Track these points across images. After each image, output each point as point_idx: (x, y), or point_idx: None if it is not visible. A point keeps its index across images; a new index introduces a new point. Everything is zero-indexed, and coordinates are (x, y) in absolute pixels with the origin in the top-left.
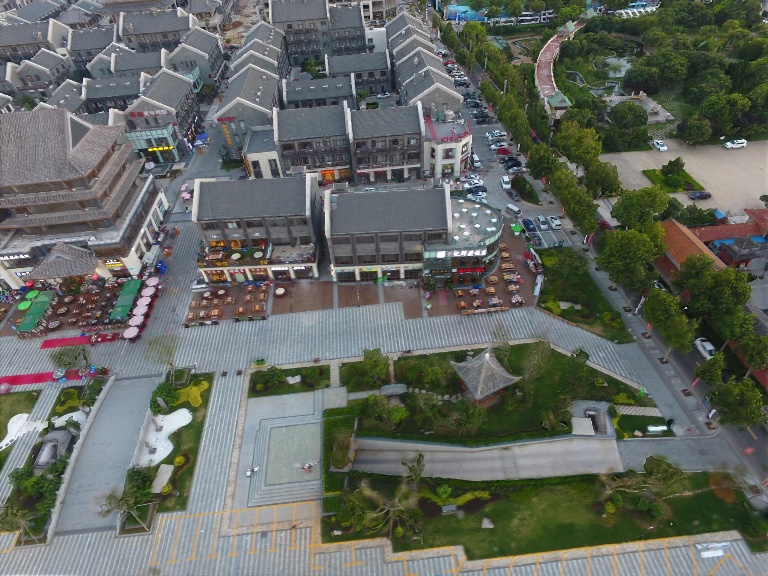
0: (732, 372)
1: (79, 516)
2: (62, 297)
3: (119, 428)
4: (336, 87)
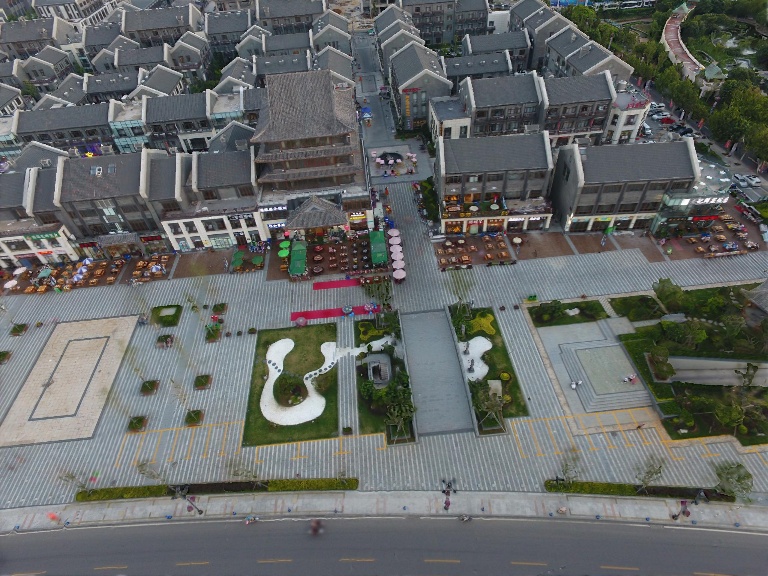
0: None
1: (434, 421)
2: (309, 247)
3: (434, 351)
4: (492, 63)
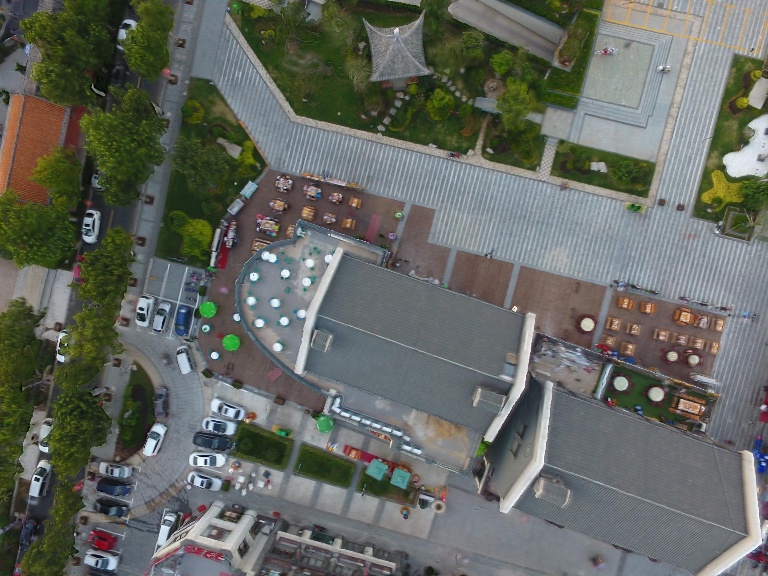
0: (127, 1)
1: None
2: None
3: None
4: None
